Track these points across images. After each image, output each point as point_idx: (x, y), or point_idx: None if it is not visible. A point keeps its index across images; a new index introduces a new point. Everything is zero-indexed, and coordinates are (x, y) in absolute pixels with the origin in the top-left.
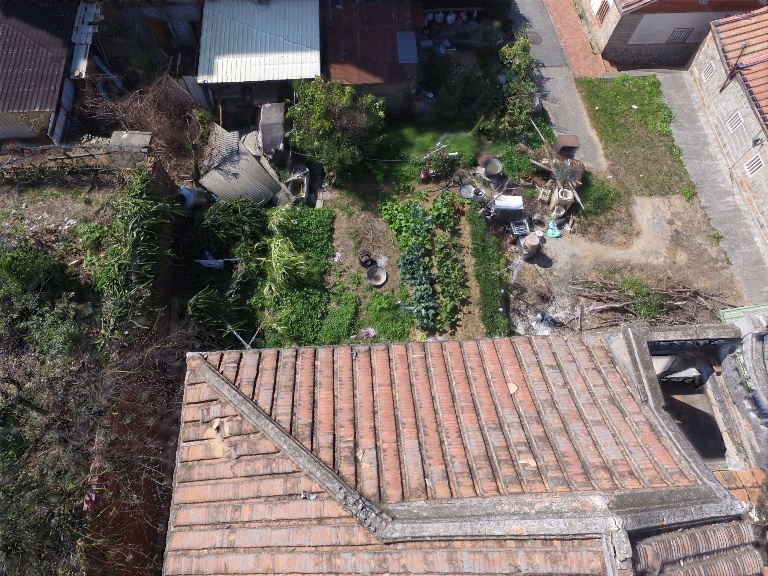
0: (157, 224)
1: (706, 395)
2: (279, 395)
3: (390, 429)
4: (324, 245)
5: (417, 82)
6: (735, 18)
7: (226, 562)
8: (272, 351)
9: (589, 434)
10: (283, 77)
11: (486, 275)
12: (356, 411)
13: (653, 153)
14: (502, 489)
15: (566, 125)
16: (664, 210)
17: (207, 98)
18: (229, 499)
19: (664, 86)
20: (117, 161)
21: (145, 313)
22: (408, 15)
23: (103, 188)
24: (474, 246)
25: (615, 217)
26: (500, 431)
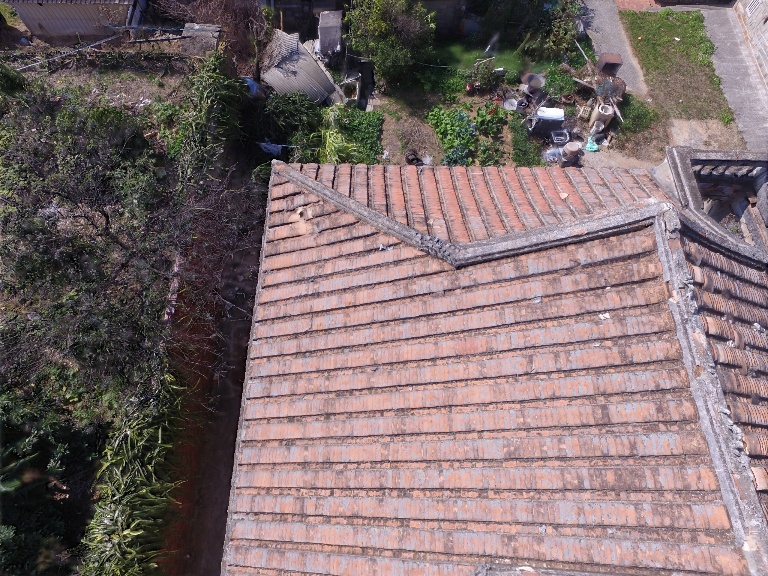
0: (228, 97)
1: None
2: (355, 188)
3: (456, 210)
4: (373, 143)
5: None
6: None
7: (311, 304)
8: (346, 164)
9: None
10: None
11: None
12: (424, 202)
13: (693, 81)
14: None
15: None
16: (701, 133)
17: (269, 5)
18: (313, 261)
19: (708, 21)
20: (189, 50)
21: (217, 170)
22: None
23: (175, 74)
24: (515, 151)
25: (653, 136)
26: (554, 216)
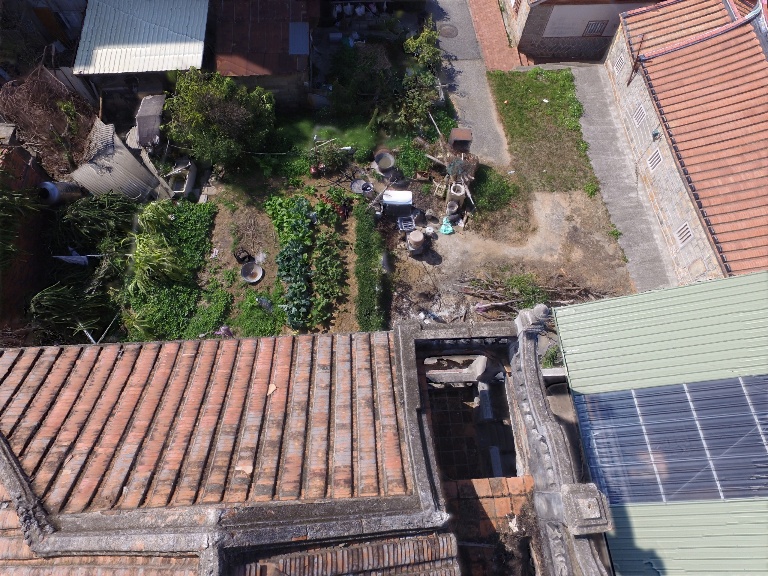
0: None
1: (557, 397)
2: (17, 396)
3: (115, 433)
4: (201, 241)
5: (308, 74)
6: (643, 9)
7: None
8: (33, 349)
9: (327, 439)
10: (163, 68)
11: (365, 272)
12: (92, 413)
13: (559, 148)
14: (200, 498)
15: (472, 119)
16: (564, 206)
17: (89, 90)
18: None
19: (578, 80)
20: None
21: None
22: (303, 5)
23: None
24: (357, 242)
25: (511, 213)
26: (233, 435)
